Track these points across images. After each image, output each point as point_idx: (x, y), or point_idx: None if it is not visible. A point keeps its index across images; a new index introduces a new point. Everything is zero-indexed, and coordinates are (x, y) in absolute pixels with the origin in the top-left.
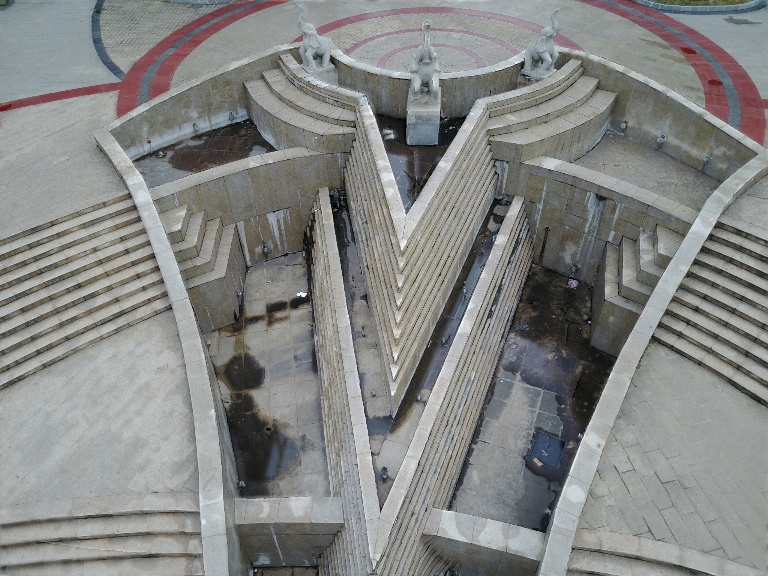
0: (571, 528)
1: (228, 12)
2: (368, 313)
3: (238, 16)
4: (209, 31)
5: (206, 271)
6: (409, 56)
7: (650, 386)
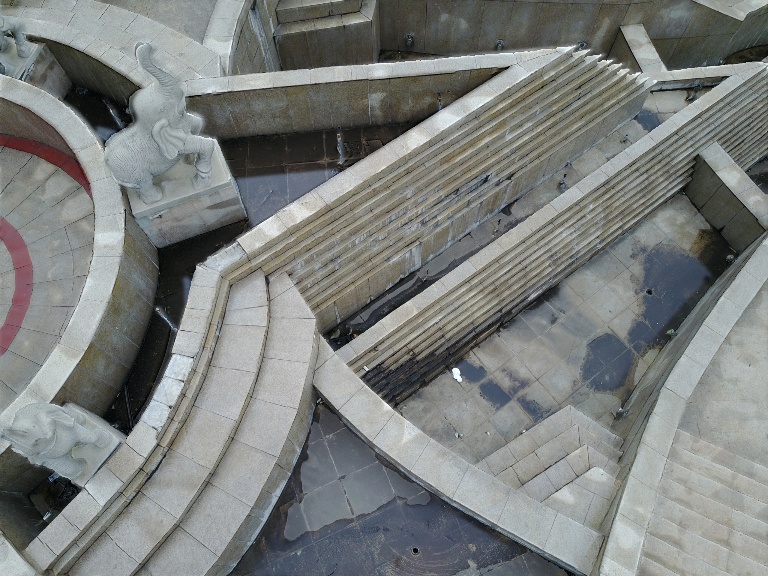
0: None
1: None
2: (528, 195)
3: None
4: None
5: None
6: None
7: None
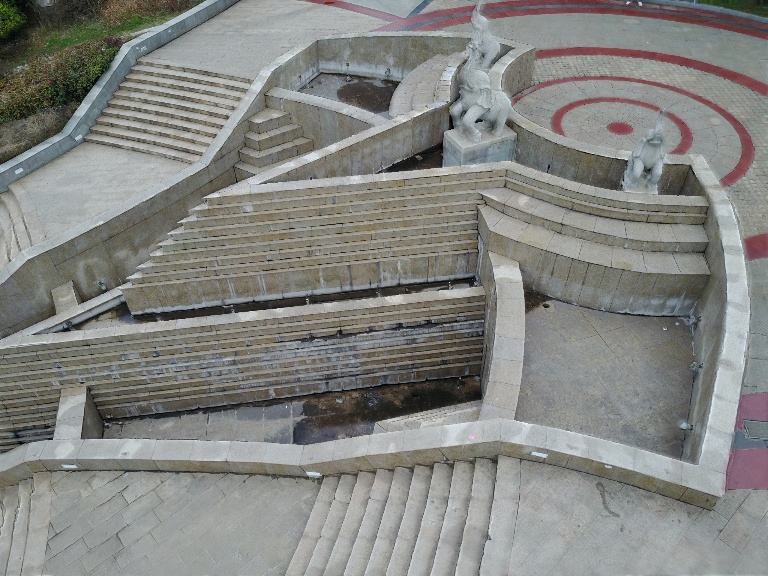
0: (27, 455)
1: (576, 4)
2: None
3: (575, 10)
4: (529, 12)
5: (256, 165)
6: (620, 110)
7: (249, 494)
